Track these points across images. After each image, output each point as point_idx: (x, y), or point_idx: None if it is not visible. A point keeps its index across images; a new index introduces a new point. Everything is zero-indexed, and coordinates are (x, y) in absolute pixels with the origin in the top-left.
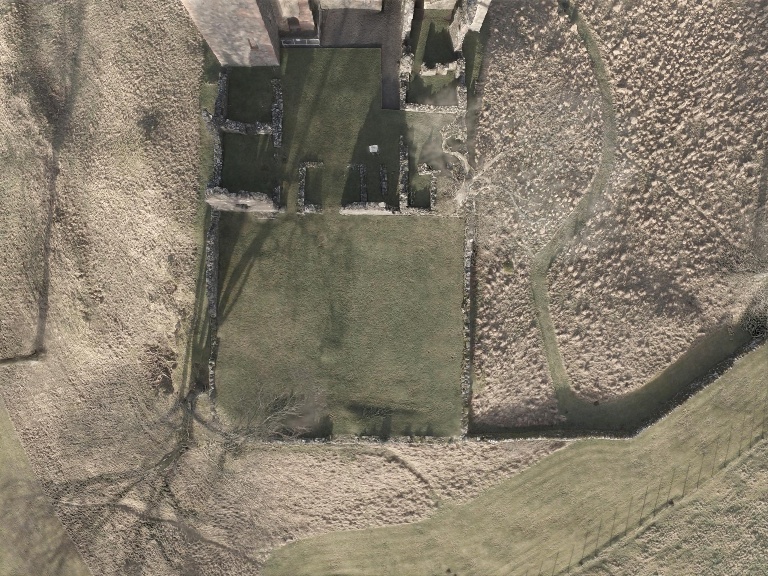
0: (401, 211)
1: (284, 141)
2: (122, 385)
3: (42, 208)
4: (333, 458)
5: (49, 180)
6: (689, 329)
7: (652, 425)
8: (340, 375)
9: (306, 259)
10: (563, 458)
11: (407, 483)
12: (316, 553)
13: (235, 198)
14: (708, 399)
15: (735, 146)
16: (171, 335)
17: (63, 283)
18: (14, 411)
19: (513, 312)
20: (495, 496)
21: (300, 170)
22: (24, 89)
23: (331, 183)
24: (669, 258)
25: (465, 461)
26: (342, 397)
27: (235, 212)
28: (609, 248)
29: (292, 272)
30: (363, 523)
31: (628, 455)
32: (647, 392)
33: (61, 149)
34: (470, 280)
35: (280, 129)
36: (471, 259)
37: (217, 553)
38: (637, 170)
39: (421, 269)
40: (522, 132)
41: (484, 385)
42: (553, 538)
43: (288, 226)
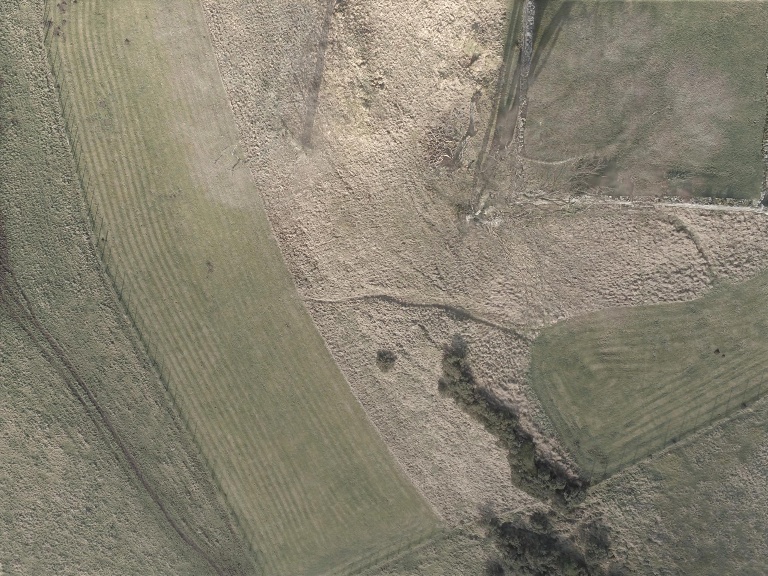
0: None
1: None
2: (398, 170)
3: (319, 4)
4: (627, 223)
5: None
6: None
7: None
8: (640, 140)
9: (611, 25)
10: None
11: (688, 258)
12: (586, 330)
13: None
14: None
15: None
16: (461, 111)
17: (341, 74)
18: (273, 211)
19: None
20: None
21: None
22: None
23: None
24: None
25: (748, 237)
26: (642, 161)
27: None
28: None
29: (598, 37)
30: (638, 299)
31: None
32: None
33: None
34: None
35: None
36: None
37: (486, 331)
38: None
39: (725, 36)
40: None
41: None
42: None
43: None
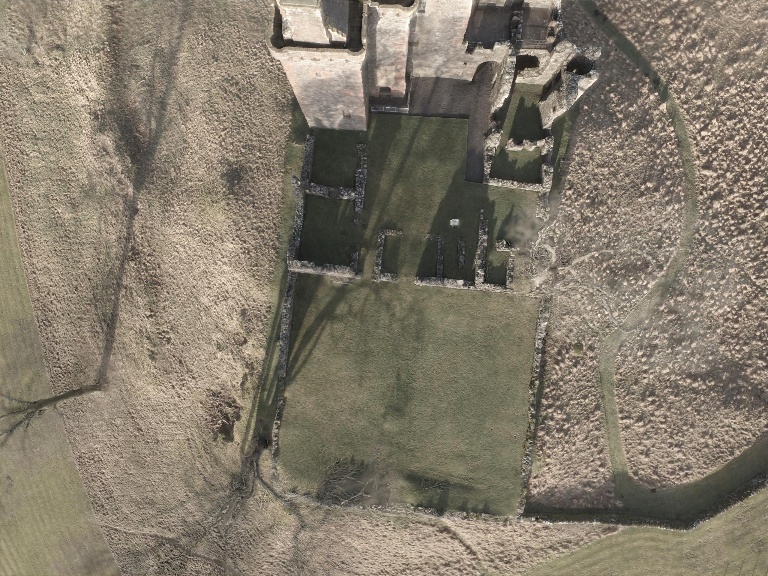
0: (476, 286)
1: (365, 207)
2: (182, 425)
3: (117, 244)
4: (387, 524)
5: (127, 219)
6: (756, 423)
7: (710, 519)
8: (401, 444)
9: (377, 326)
10: (615, 542)
11: (456, 553)
12: None
13: (320, 271)
14: None
15: None
16: (236, 385)
17: (132, 320)
18: (72, 434)
19: (579, 394)
20: (542, 573)
21: (379, 237)
22: (110, 127)
23: (408, 252)
24: (741, 348)
25: (516, 537)
26: (401, 466)
27: (311, 274)
28: (680, 334)
29: (362, 338)
30: None
31: (681, 545)
32: (707, 484)
33: (142, 190)
34: None
35: (363, 195)
36: None
37: None
38: (715, 255)
39: (491, 345)
40: (602, 212)
41: (544, 466)
42: None
43: (362, 292)
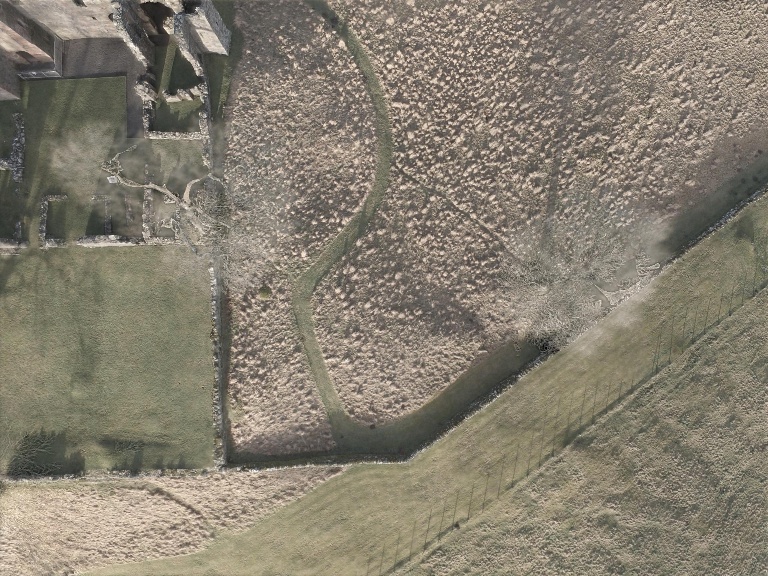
0: (145, 241)
1: (26, 176)
2: None
3: None
4: (91, 493)
5: None
6: (468, 347)
7: (426, 448)
8: (92, 409)
9: (53, 294)
10: (340, 484)
11: (178, 515)
12: None
13: None
14: (492, 418)
15: (521, 156)
16: None
17: None
18: None
19: (273, 338)
20: (272, 525)
21: (42, 204)
22: None
23: (75, 216)
24: (449, 275)
25: (235, 491)
26: (94, 432)
27: None
28: (382, 267)
29: (39, 307)
30: (139, 556)
31: (408, 478)
32: (426, 413)
33: None
34: (224, 308)
35: (19, 164)
36: (224, 286)
37: None
38: (414, 186)
39: (170, 299)
40: (282, 154)
41: (243, 414)
42: (334, 565)
43: (33, 261)
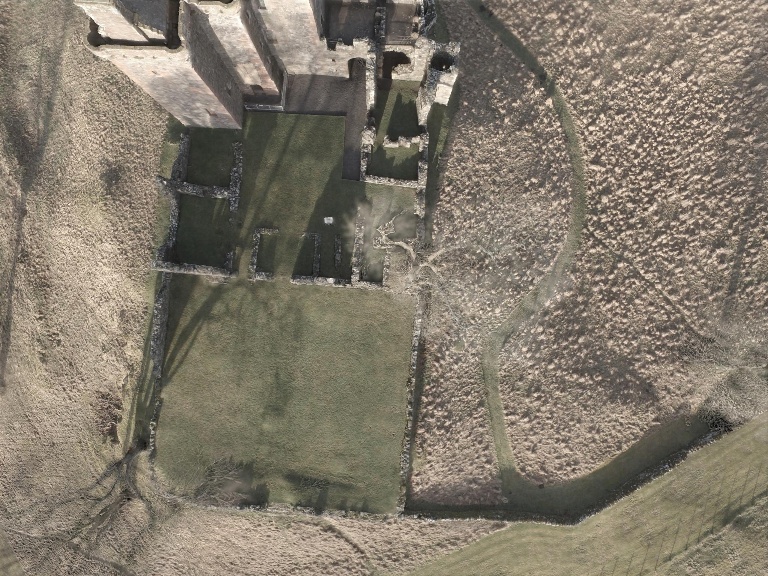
0: (352, 284)
1: (241, 206)
2: (74, 427)
3: (9, 246)
4: (269, 524)
5: (16, 220)
6: (643, 418)
7: (596, 514)
8: (281, 443)
9: (255, 325)
10: (503, 539)
11: (343, 552)
12: None
13: (178, 271)
14: (658, 490)
15: (709, 231)
16: (121, 386)
17: (24, 322)
18: None
19: (461, 391)
20: (432, 571)
21: (254, 236)
22: None
23: (285, 251)
24: (629, 343)
25: (403, 535)
26: (281, 465)
27: (187, 274)
28: (567, 329)
29: (240, 337)
30: None
31: (570, 541)
32: (595, 479)
33: (29, 191)
34: (418, 357)
35: (237, 194)
36: (421, 336)
37: None
38: (603, 250)
39: (369, 343)
40: (485, 208)
41: (425, 463)
42: None
43: (239, 291)
